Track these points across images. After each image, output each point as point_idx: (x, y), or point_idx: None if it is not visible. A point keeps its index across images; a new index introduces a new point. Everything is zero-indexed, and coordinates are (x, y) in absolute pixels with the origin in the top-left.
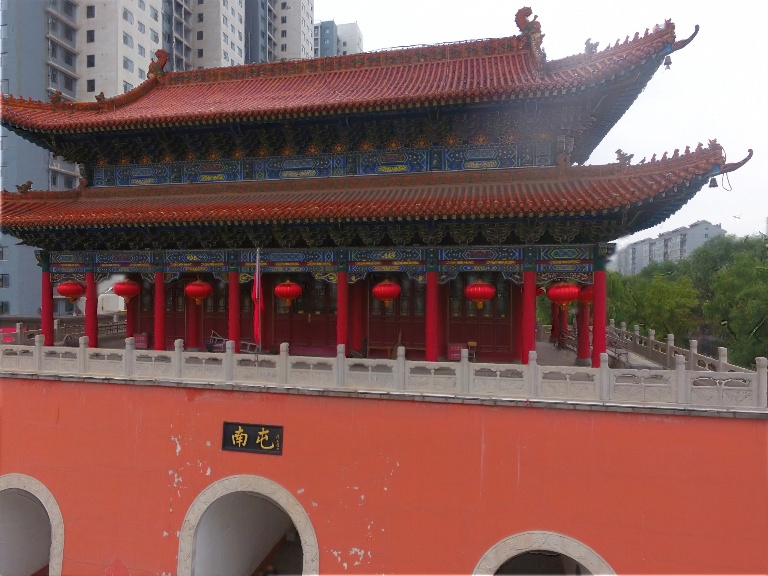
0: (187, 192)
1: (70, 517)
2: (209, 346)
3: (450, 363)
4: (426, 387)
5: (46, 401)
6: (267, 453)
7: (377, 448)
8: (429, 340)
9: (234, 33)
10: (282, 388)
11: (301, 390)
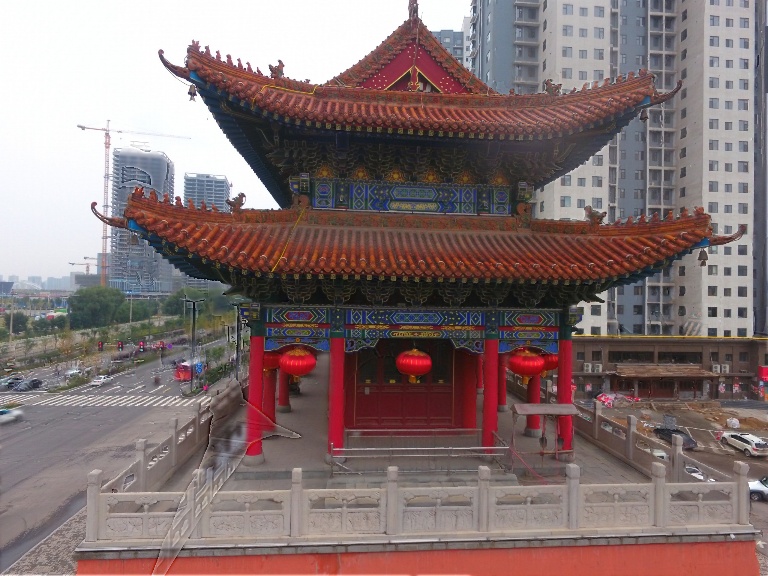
0: None
1: None
2: None
3: None
4: None
5: None
6: None
7: None
8: None
9: (732, 6)
10: None
11: None
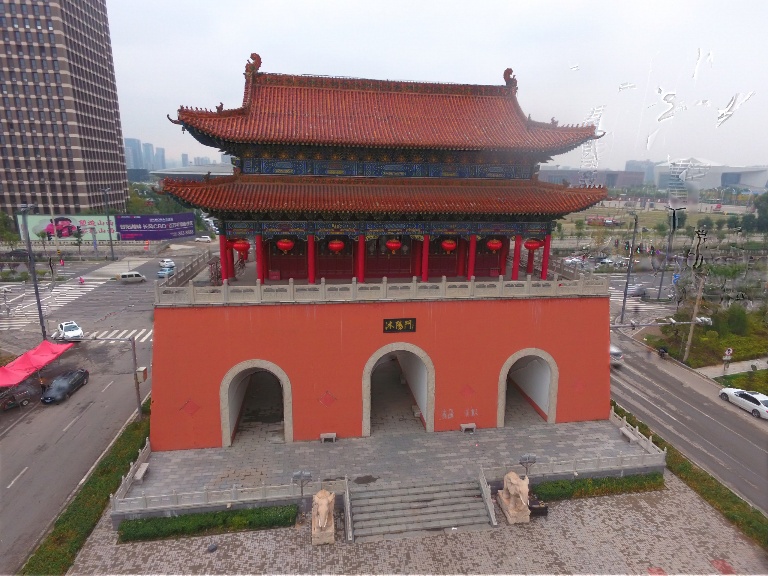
0: None
1: None
2: None
3: None
4: None
5: None
6: None
7: None
8: None
9: None
10: None
11: None
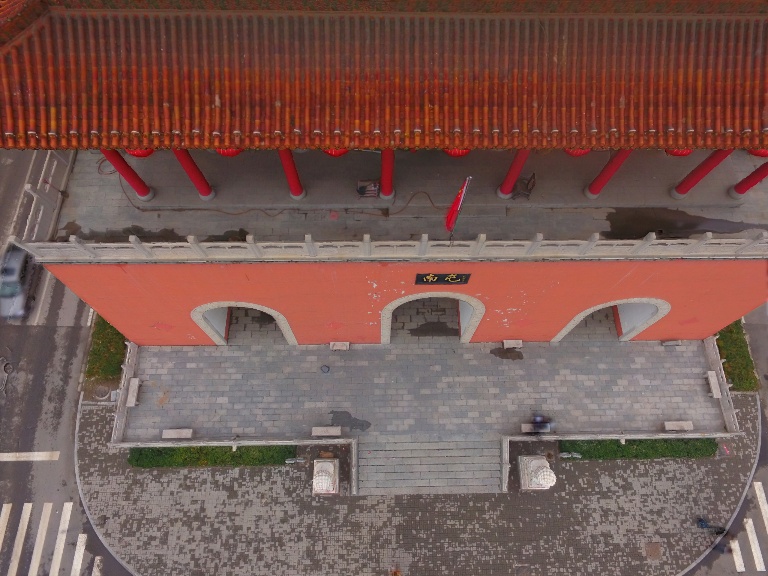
0: (280, 7)
1: (286, 312)
2: (362, 192)
3: (634, 242)
4: (603, 252)
5: (228, 272)
6: (455, 284)
7: (546, 278)
8: (603, 182)
9: None
10: (476, 260)
11: (493, 260)
